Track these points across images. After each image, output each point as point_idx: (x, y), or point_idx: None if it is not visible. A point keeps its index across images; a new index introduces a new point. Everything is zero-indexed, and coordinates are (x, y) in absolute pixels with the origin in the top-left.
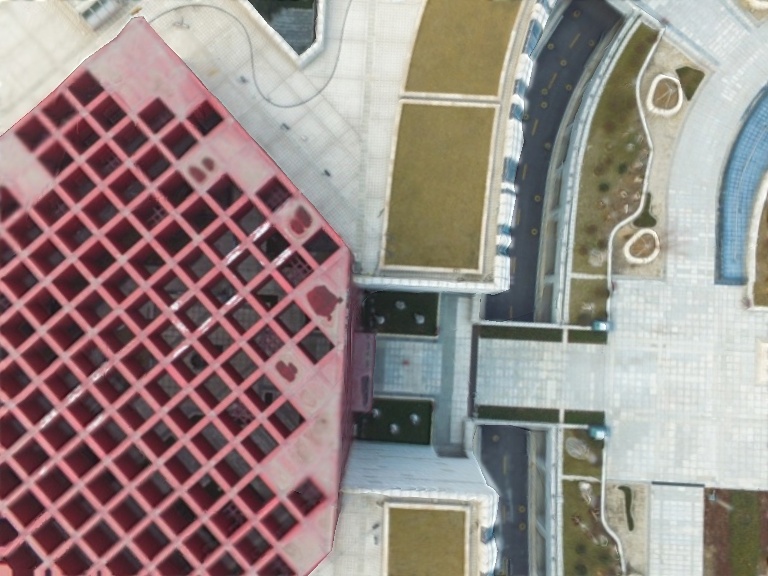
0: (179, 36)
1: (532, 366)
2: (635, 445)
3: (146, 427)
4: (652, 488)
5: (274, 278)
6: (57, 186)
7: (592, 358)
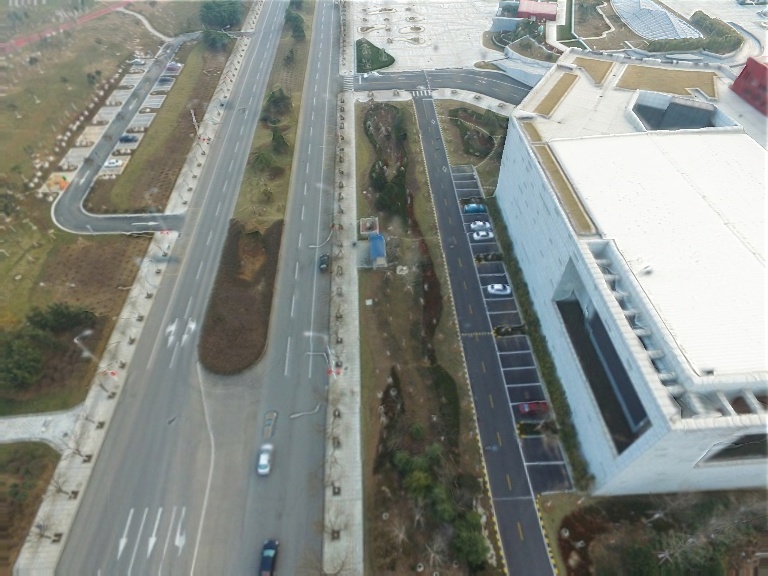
0: None
1: None
2: (725, 2)
3: None
4: None
5: None
6: None
7: None
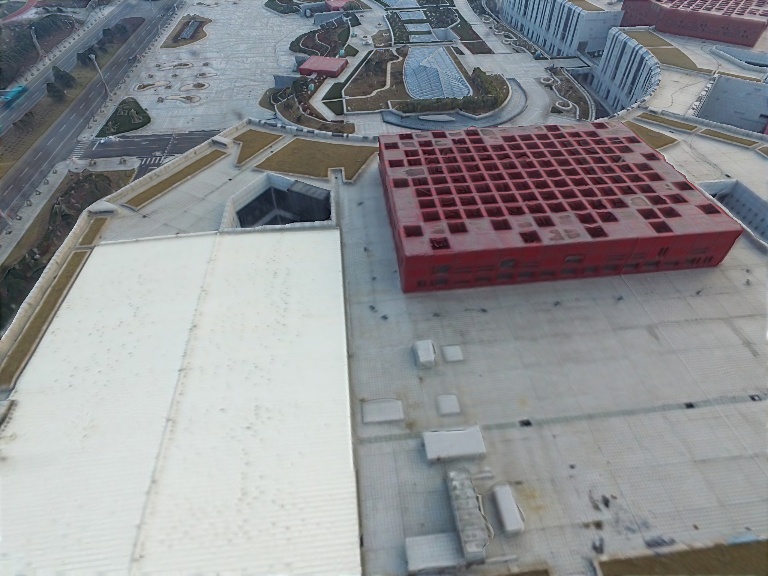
0: (759, 50)
1: None
2: None
3: None
4: None
5: (680, 4)
6: (749, 7)
7: None
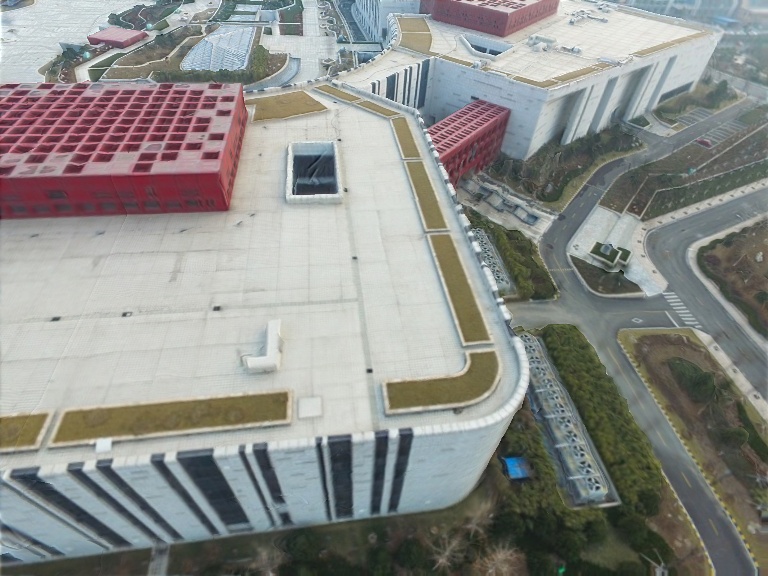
0: (506, 40)
1: (363, 48)
2: None
3: None
4: None
5: None
6: None
7: None
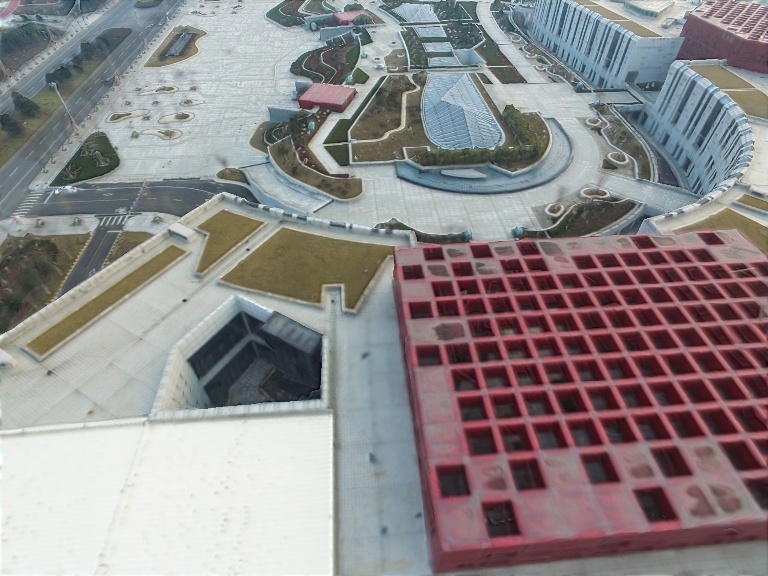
0: None
1: None
2: (560, 88)
3: (760, 20)
4: (547, 82)
5: None
6: None
7: (591, 101)
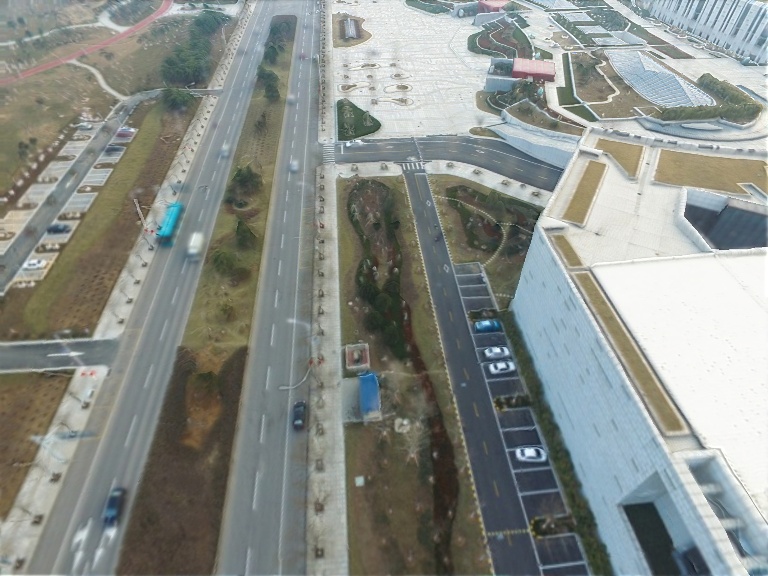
0: None
1: None
2: None
3: None
4: None
5: None
6: None
7: None
